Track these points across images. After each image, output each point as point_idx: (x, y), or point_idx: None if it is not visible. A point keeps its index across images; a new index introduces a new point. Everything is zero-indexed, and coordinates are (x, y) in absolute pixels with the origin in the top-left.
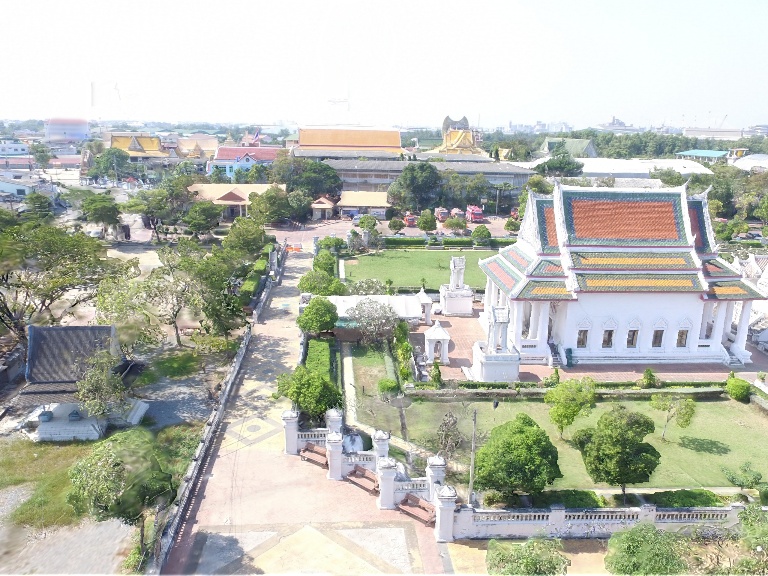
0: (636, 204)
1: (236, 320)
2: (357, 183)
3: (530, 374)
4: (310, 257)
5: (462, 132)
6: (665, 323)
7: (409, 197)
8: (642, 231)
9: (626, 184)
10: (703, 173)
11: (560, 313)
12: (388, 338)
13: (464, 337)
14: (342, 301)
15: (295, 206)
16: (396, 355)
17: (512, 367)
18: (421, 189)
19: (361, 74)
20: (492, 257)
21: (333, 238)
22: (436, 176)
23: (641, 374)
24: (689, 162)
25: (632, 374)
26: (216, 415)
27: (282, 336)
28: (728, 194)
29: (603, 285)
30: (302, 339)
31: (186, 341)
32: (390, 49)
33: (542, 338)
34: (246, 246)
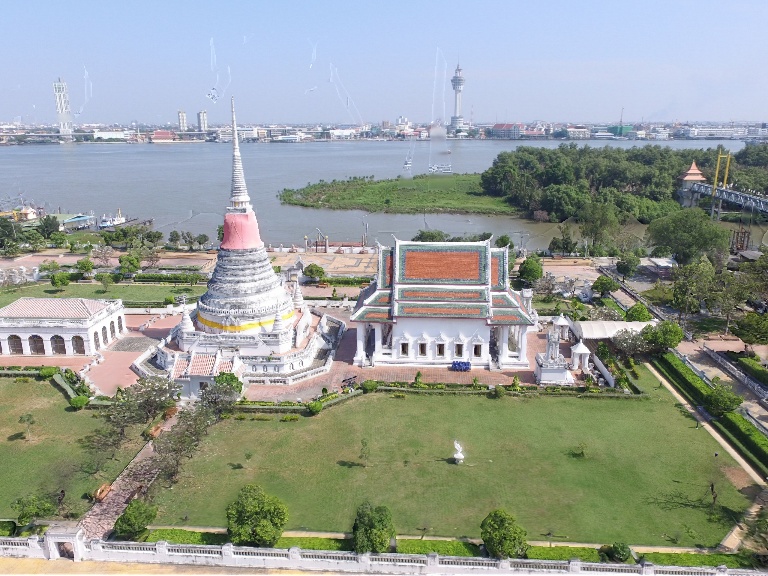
0: None
1: None
2: None
3: None
4: None
5: None
6: None
7: None
8: None
9: None
10: None
11: None
12: None
13: None
14: None
15: None
16: None
17: None
18: None
19: None
20: None
21: None
22: None
23: None
24: None
25: None
26: (645, 302)
27: None
28: None
29: None
30: None
31: None
32: None
33: None
34: None
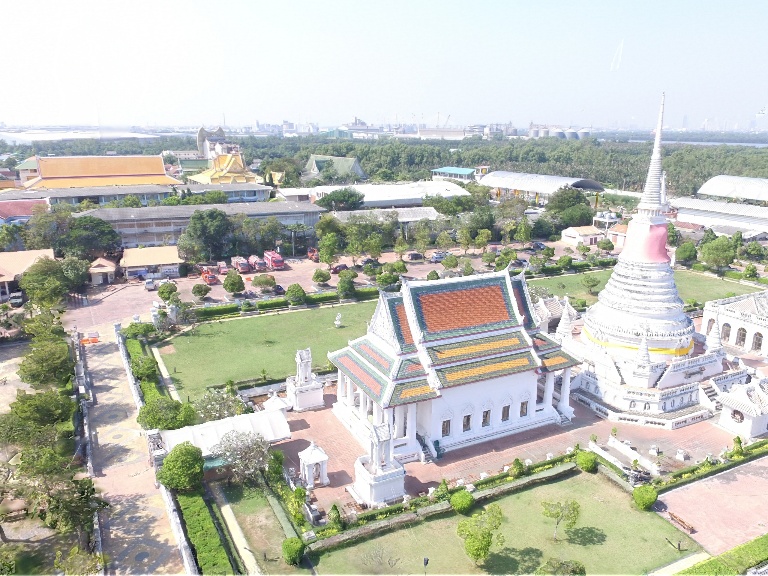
0: (472, 291)
1: (92, 506)
2: (136, 234)
3: (409, 477)
4: (115, 350)
5: (231, 156)
6: (511, 399)
7: (200, 247)
8: (481, 317)
9: (406, 214)
10: (463, 195)
11: (423, 406)
12: (260, 468)
13: (328, 439)
14: (200, 435)
15: (71, 276)
16: (276, 490)
17: (399, 481)
18: (213, 239)
19: (112, 98)
20: (342, 350)
21: (140, 324)
22: (227, 223)
23: (500, 452)
24: (449, 184)
25: (493, 454)
26: None
27: (135, 492)
28: (491, 220)
29: (460, 377)
30: (171, 501)
31: (11, 532)
32: (142, 70)
33: (412, 436)
34: (52, 372)
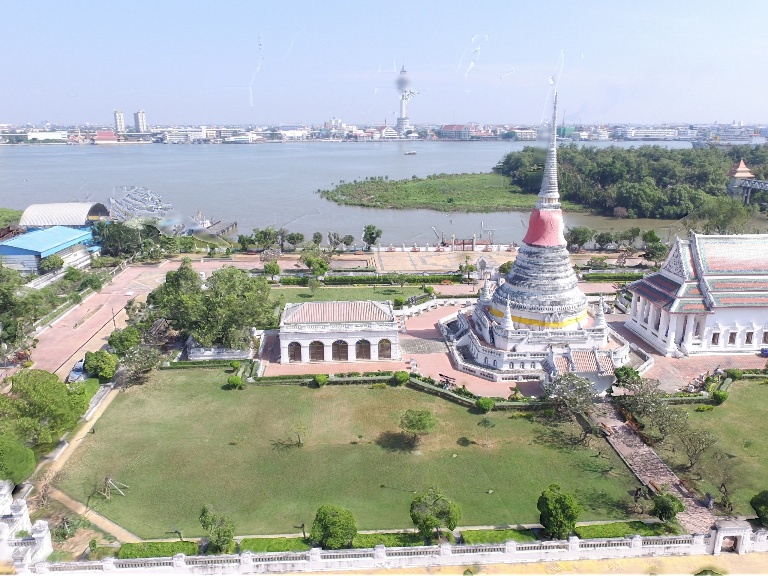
0: None
1: None
2: None
3: None
4: None
5: None
6: None
7: None
8: None
9: None
10: None
11: None
12: None
13: None
14: None
15: None
16: None
17: None
18: None
19: None
20: None
21: None
22: None
23: None
24: None
25: None
26: None
27: None
28: None
29: None
30: None
31: None
32: None
33: None
34: None
